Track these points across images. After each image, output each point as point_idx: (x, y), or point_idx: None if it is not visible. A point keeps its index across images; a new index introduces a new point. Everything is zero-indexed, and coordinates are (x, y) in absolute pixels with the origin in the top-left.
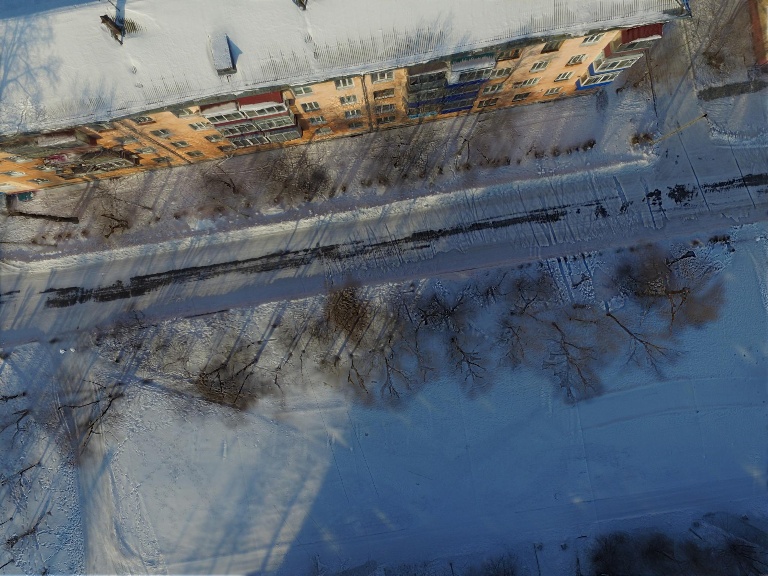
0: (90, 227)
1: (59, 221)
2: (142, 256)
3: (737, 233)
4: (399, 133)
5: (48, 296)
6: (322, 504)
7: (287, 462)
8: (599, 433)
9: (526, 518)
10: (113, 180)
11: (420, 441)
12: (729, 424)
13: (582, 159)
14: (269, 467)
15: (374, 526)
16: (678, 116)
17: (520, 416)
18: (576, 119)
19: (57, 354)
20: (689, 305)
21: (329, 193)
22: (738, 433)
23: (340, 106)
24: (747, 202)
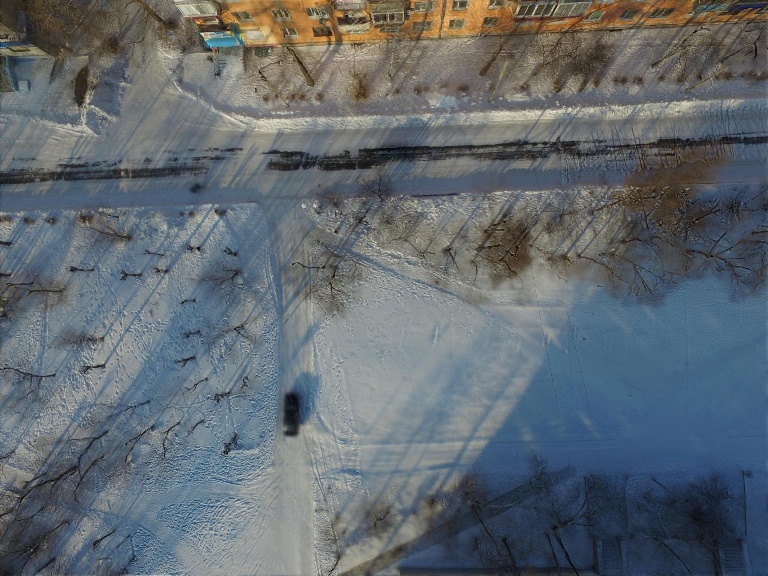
0: (324, 91)
1: (305, 76)
2: (374, 128)
3: None
4: (660, 33)
5: (271, 157)
6: (529, 403)
7: (498, 356)
8: None
9: (738, 444)
10: (354, 46)
11: (639, 352)
12: None
13: None
14: (480, 359)
15: (580, 432)
16: None
17: (747, 339)
18: None
19: (273, 218)
20: None
21: (581, 85)
22: None
23: None
24: None
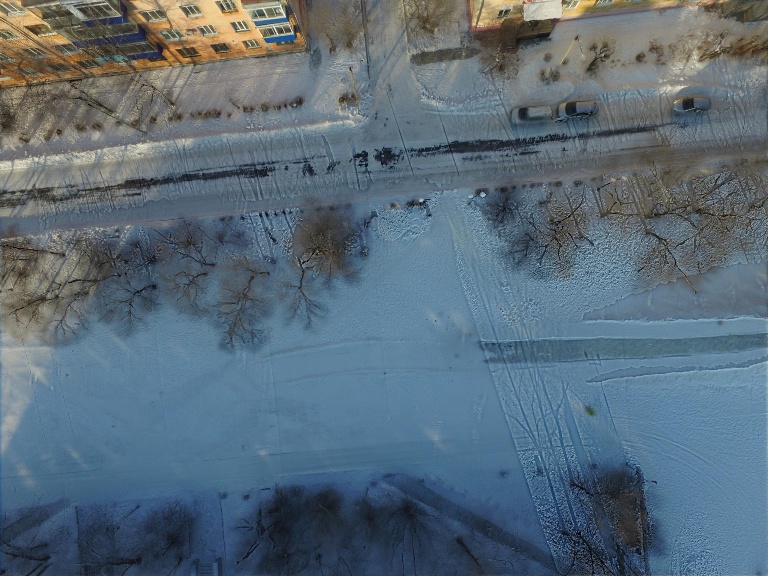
0: None
1: None
2: None
3: (438, 199)
4: (117, 80)
5: None
6: (20, 440)
7: None
8: (290, 388)
9: (214, 467)
10: None
11: (117, 385)
12: (415, 388)
13: (291, 116)
14: None
15: (69, 465)
16: (390, 79)
17: (214, 366)
18: (289, 76)
19: None
20: (386, 268)
21: (43, 135)
22: (423, 397)
23: (6, 41)
24: (451, 169)
